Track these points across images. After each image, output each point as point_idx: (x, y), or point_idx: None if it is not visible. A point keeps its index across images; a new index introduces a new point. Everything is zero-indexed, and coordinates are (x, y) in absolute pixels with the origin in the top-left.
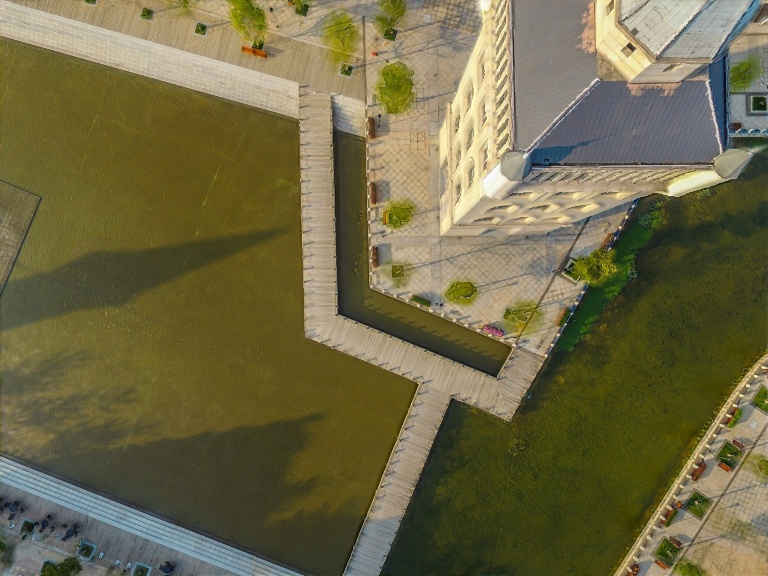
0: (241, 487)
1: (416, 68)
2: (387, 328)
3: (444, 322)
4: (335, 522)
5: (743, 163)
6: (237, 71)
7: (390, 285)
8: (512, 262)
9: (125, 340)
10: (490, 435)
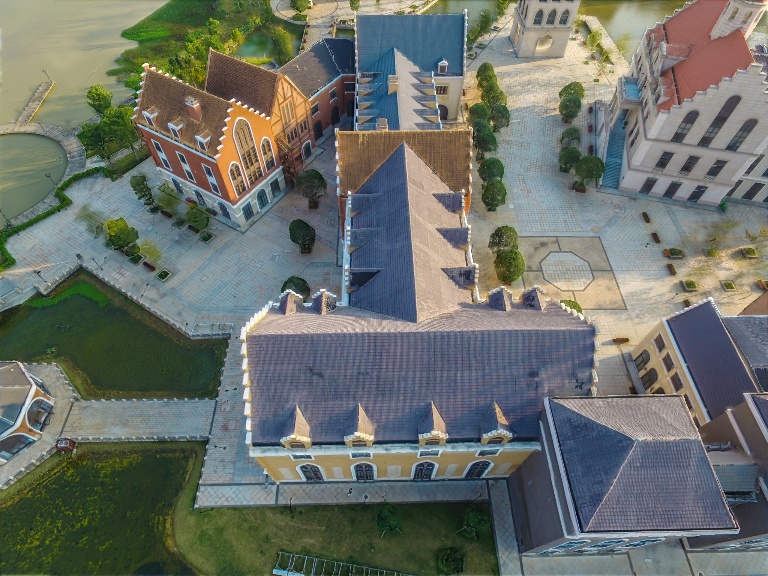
0: None
1: (581, 72)
2: None
3: None
4: None
5: None
6: None
7: None
8: None
9: None
10: None
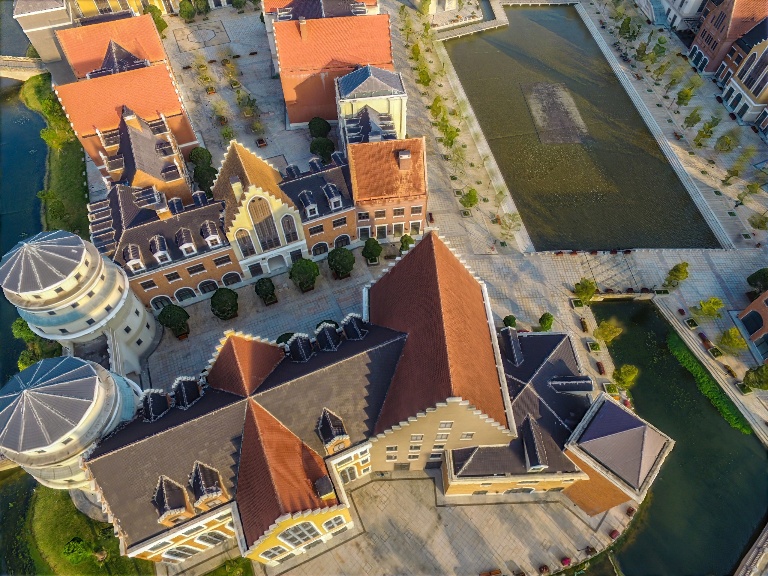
0: None
1: None
2: None
3: None
4: None
5: None
6: (439, 53)
7: (479, 13)
8: None
9: None
10: None
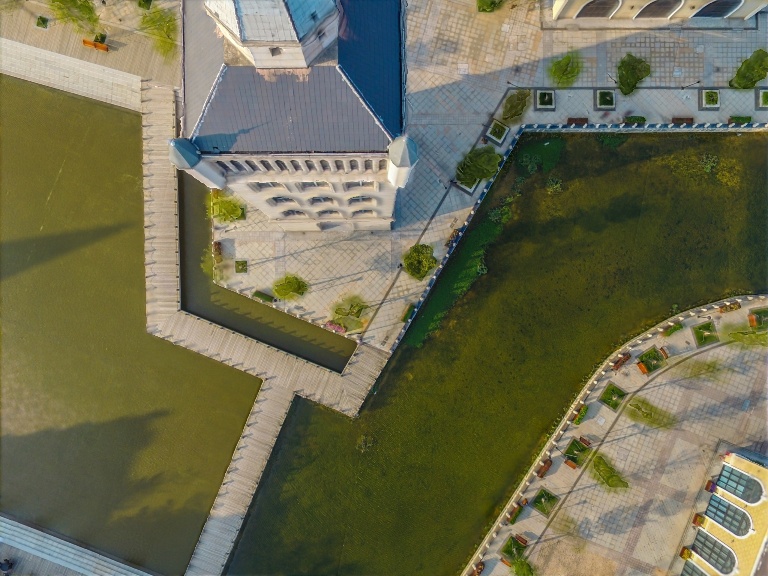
0: (85, 484)
1: None
2: (233, 324)
3: (291, 318)
4: (180, 519)
5: (403, 151)
6: (79, 65)
7: (233, 280)
8: (357, 257)
9: None
10: (338, 432)
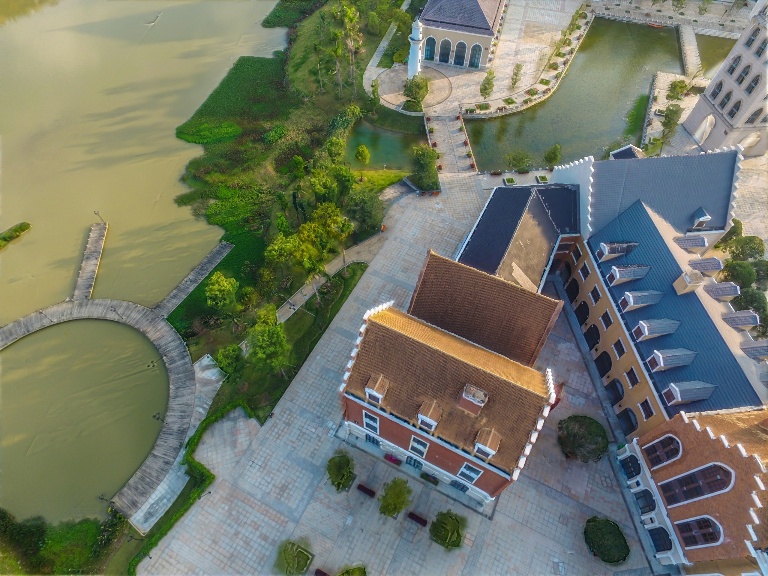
0: None
1: None
2: None
3: None
4: None
5: None
6: None
7: None
8: None
9: None
10: None
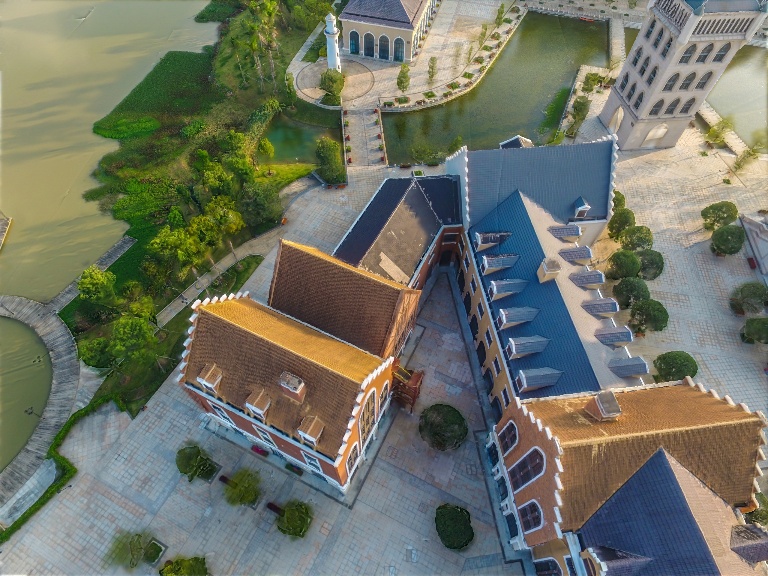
0: None
1: (703, 169)
2: None
3: None
4: None
5: None
6: None
7: None
8: None
9: (762, 81)
10: None
